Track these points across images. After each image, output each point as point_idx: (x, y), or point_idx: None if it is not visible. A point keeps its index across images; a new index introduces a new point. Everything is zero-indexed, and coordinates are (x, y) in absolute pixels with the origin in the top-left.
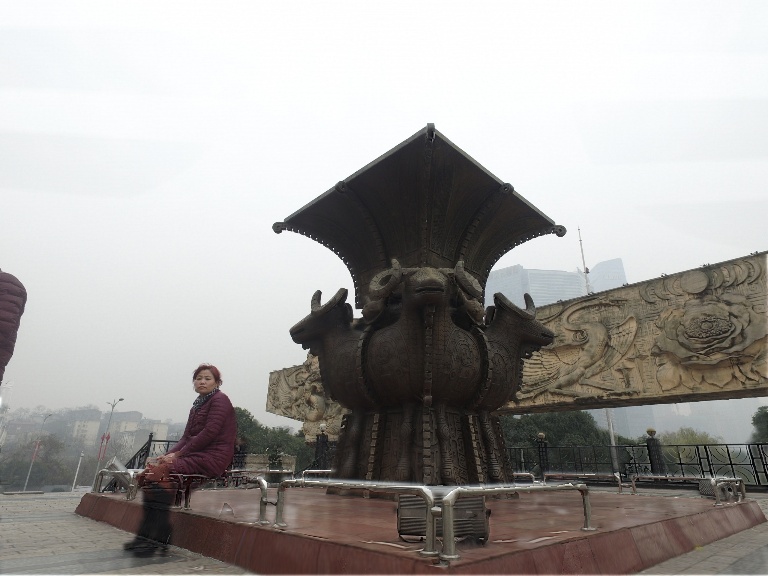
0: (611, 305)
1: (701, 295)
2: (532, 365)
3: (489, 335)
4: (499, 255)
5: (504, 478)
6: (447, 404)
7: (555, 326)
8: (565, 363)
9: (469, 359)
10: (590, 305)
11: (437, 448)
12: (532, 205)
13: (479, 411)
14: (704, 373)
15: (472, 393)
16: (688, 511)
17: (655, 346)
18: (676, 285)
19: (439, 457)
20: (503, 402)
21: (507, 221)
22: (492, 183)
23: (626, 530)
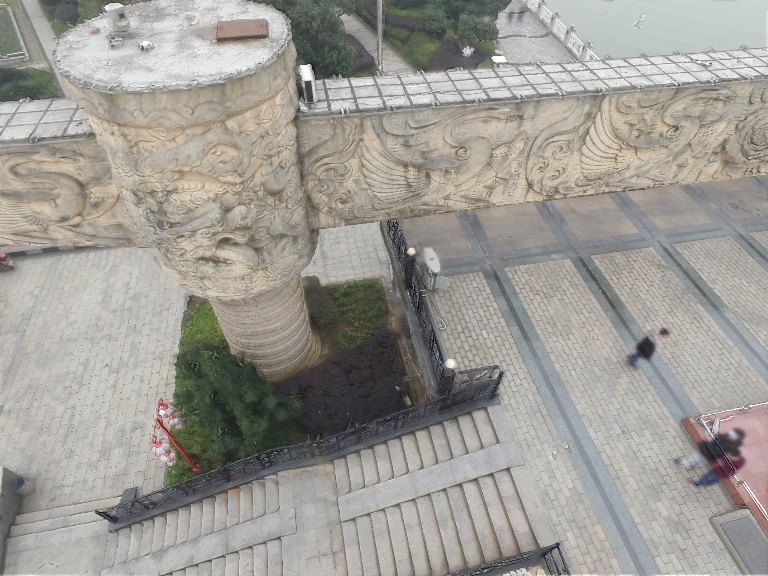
0: None
1: None
2: (604, 159)
3: None
4: None
5: None
6: None
7: (653, 116)
8: (641, 159)
9: None
10: None
11: None
12: None
13: None
14: (733, 169)
15: None
16: None
17: (721, 146)
18: None
19: None
20: None
21: None
22: None
23: None
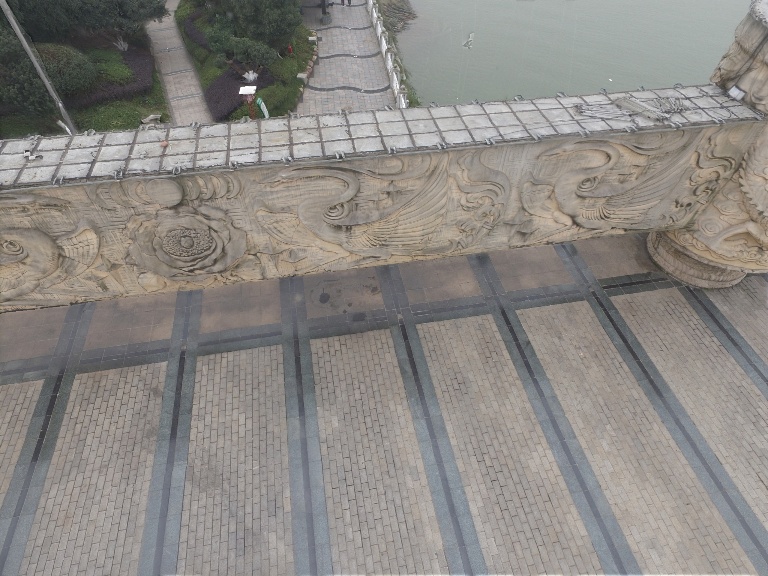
0: (45, 208)
1: (175, 206)
2: None
3: None
4: None
5: None
6: None
7: None
8: (1, 278)
9: None
10: (5, 207)
11: None
12: None
13: None
14: None
15: None
16: None
17: (129, 256)
18: (140, 191)
19: None
20: None
21: None
22: None
23: None
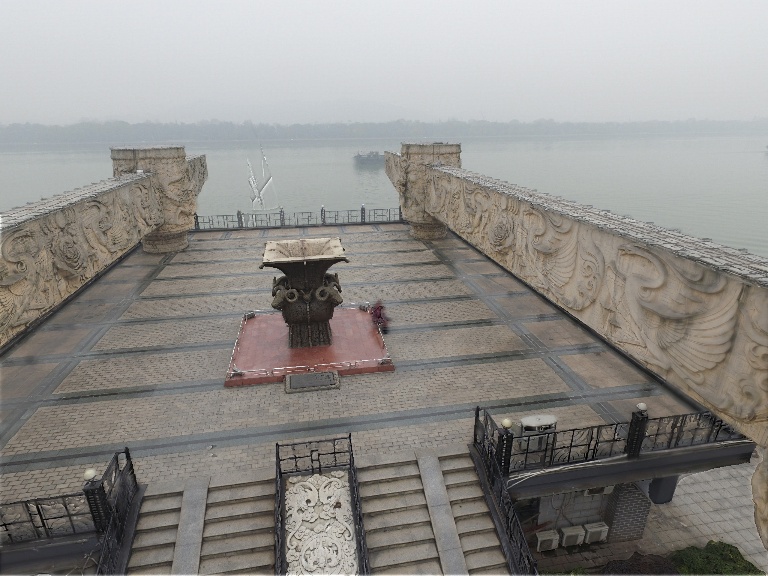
0: (29, 236)
1: None
2: None
3: None
4: None
5: None
6: None
7: None
8: None
9: None
10: (19, 236)
11: None
12: None
13: None
14: None
15: None
16: None
17: (54, 268)
18: None
19: None
20: None
21: None
22: None
23: None
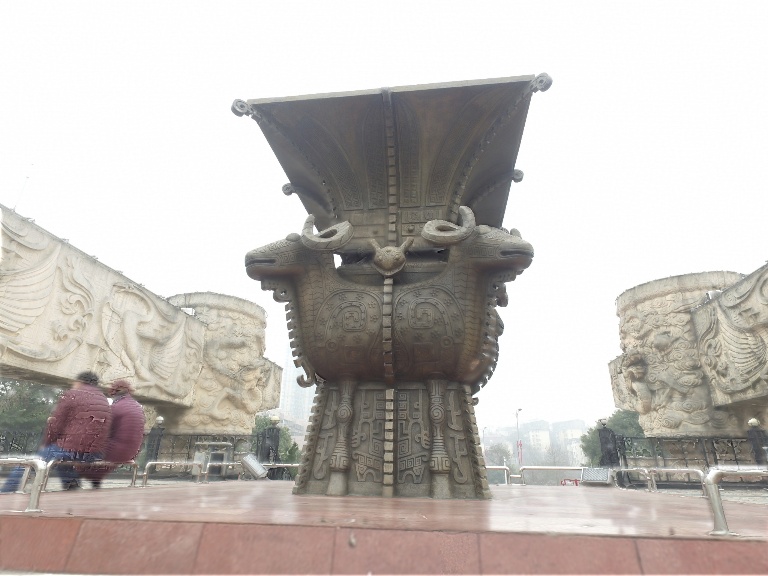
0: None
1: None
2: None
3: (428, 281)
4: (469, 167)
5: (466, 470)
6: (362, 380)
7: None
8: None
9: (358, 322)
10: None
11: (333, 432)
12: (463, 82)
13: (425, 382)
14: None
15: (381, 361)
16: (445, 526)
17: None
18: None
19: (334, 443)
20: (460, 364)
21: (447, 122)
22: (371, 100)
23: (73, 519)
